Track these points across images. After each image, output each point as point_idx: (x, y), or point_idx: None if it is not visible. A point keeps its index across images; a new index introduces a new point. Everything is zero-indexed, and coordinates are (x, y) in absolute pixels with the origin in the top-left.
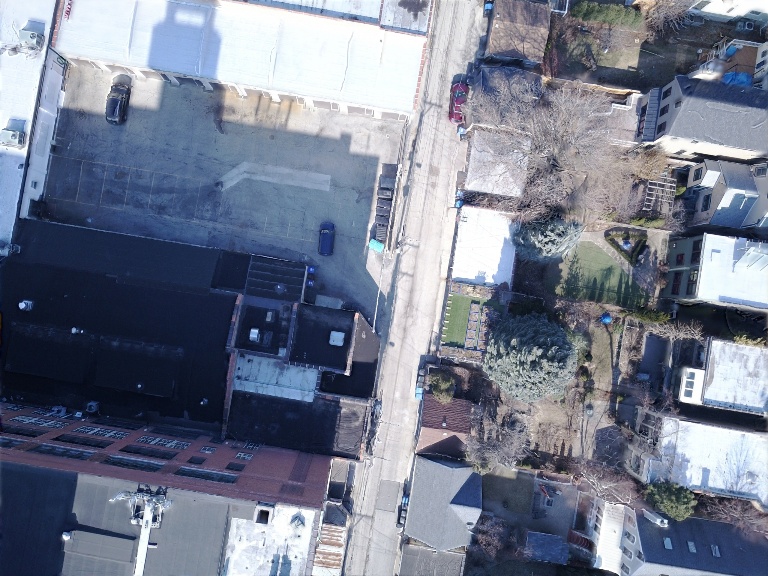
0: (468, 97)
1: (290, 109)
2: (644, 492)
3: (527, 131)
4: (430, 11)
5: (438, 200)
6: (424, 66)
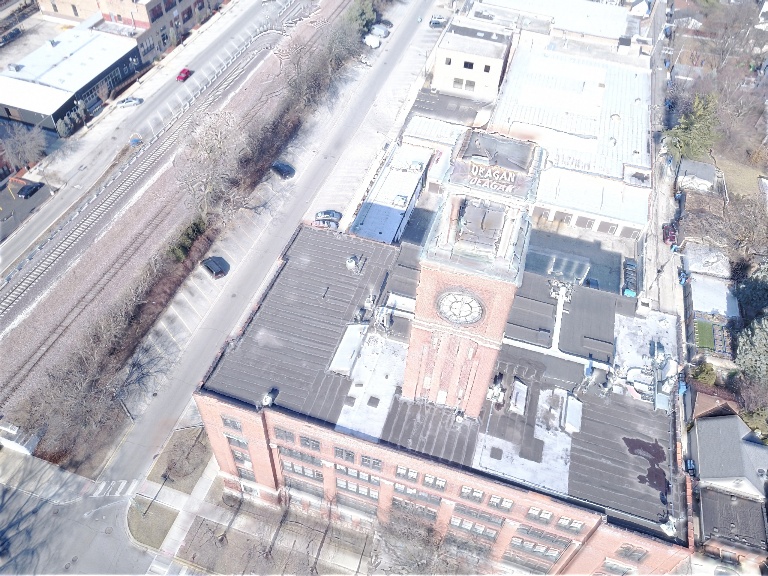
0: (676, 231)
1: (559, 225)
2: None
3: (724, 244)
4: (651, 180)
5: (667, 279)
6: (651, 204)
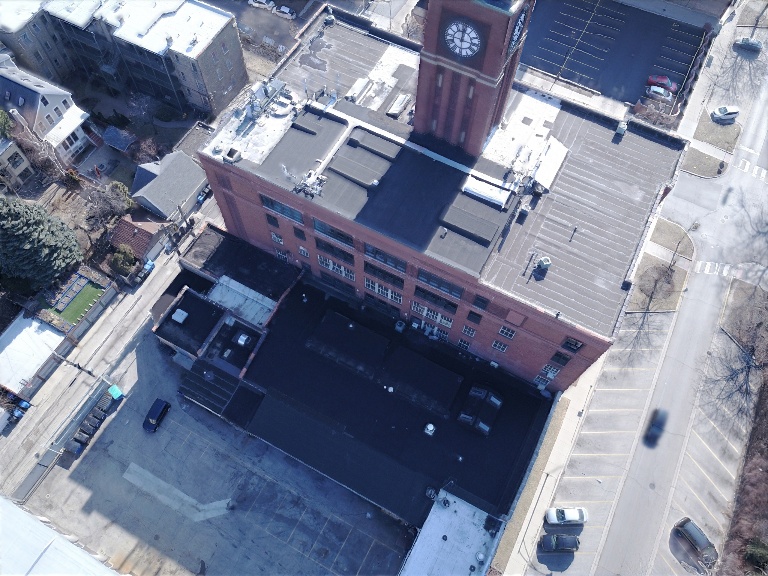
0: None
1: (124, 562)
2: (18, 138)
3: None
4: None
5: None
6: None
